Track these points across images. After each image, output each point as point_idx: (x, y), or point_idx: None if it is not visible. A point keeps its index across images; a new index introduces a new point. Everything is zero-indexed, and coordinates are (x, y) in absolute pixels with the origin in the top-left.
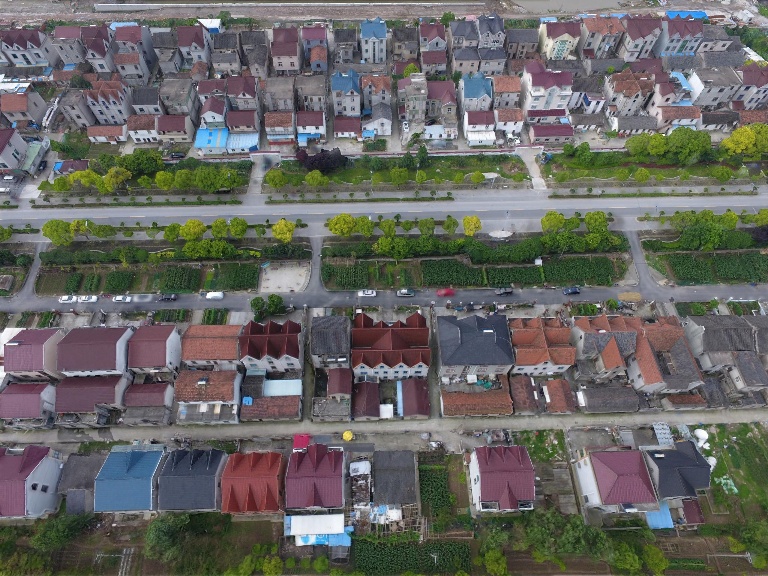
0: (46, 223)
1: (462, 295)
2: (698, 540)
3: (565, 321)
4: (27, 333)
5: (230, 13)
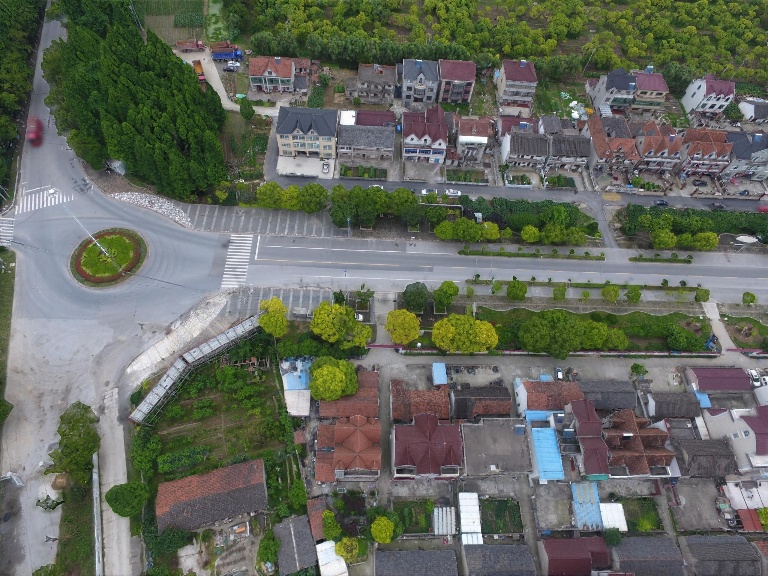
0: None
1: (750, 208)
2: (585, 82)
3: (667, 180)
4: None
5: None
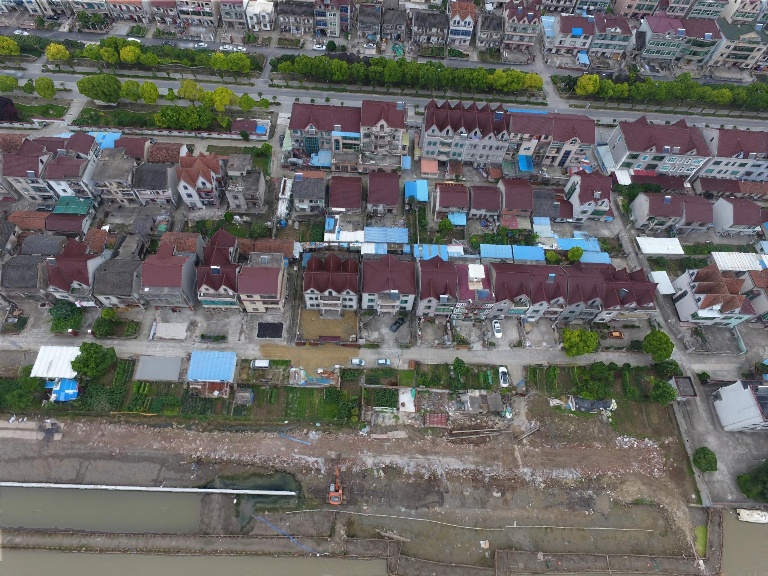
0: (245, 62)
1: None
2: None
3: None
4: (238, 0)
5: (8, 401)
